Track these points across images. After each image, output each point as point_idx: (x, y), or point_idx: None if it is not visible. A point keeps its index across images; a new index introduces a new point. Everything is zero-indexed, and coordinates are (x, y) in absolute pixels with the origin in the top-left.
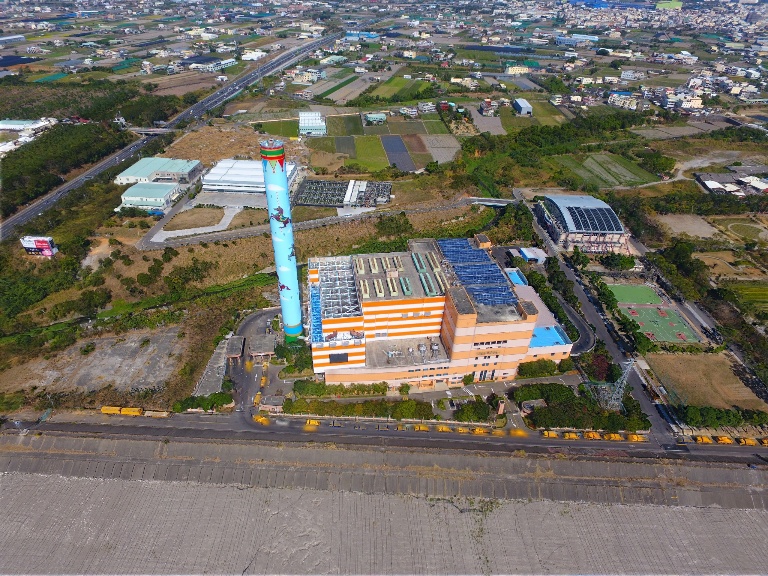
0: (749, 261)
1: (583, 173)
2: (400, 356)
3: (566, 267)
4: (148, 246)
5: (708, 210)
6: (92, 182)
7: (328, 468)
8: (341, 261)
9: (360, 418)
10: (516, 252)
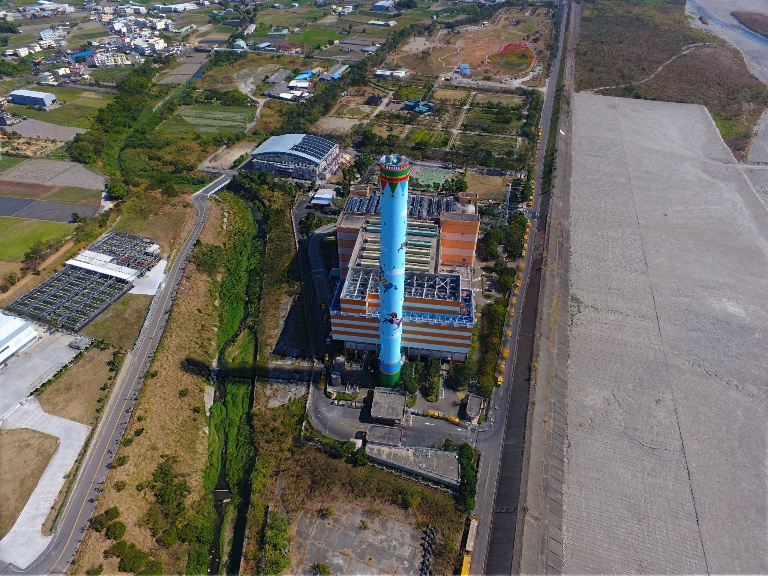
0: (389, 125)
1: (207, 129)
2: None
3: None
4: (49, 569)
5: (328, 109)
6: None
7: (552, 375)
8: (352, 277)
9: None
10: (318, 201)
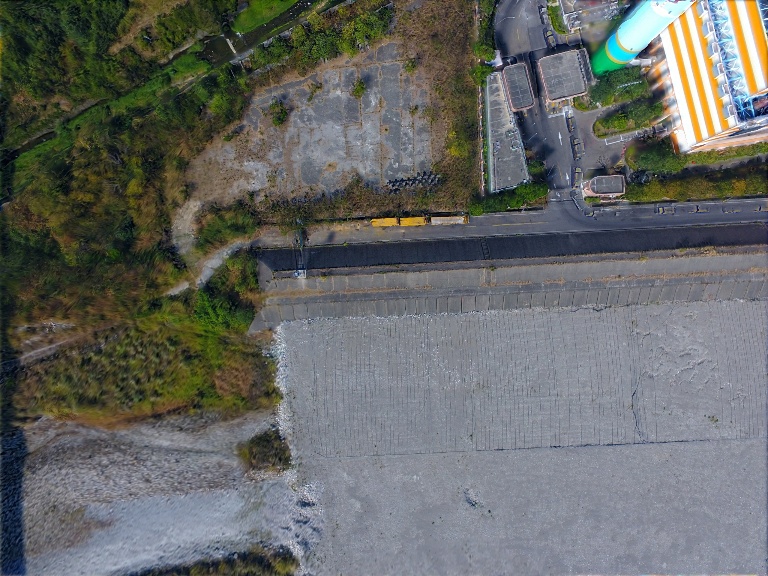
0: None
1: None
2: None
3: None
4: None
5: None
6: None
7: (704, 278)
8: None
9: None
10: None
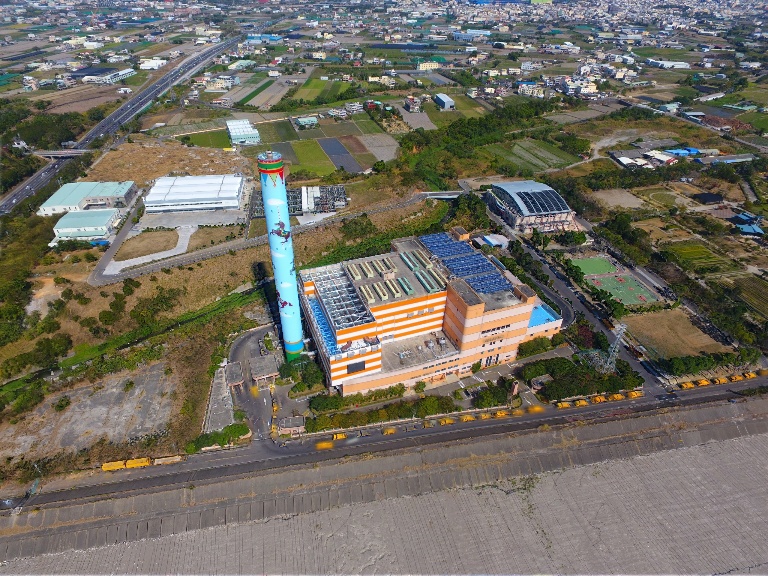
0: (675, 224)
1: (515, 160)
2: (411, 355)
3: (528, 249)
4: (103, 280)
5: (631, 183)
6: (10, 217)
7: (370, 479)
8: (332, 269)
9: (385, 423)
10: (481, 240)
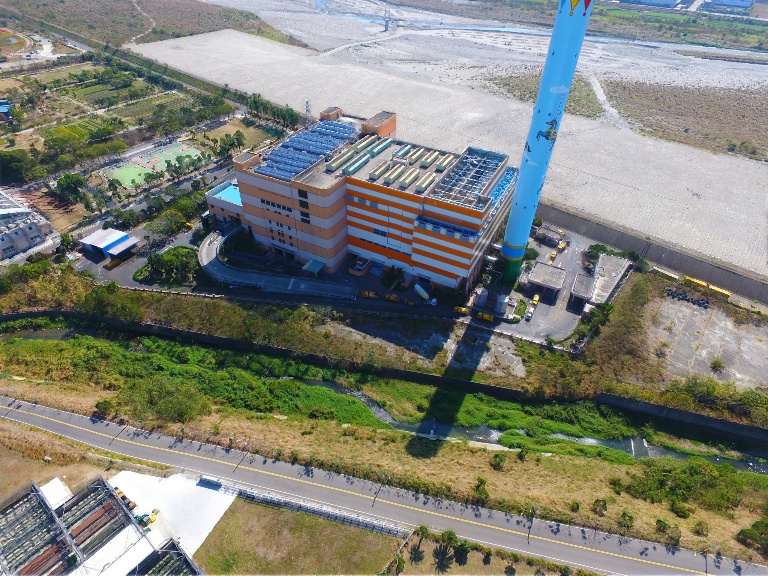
0: None
1: None
2: None
3: None
4: None
5: None
6: None
7: None
8: None
9: None
10: (119, 247)
